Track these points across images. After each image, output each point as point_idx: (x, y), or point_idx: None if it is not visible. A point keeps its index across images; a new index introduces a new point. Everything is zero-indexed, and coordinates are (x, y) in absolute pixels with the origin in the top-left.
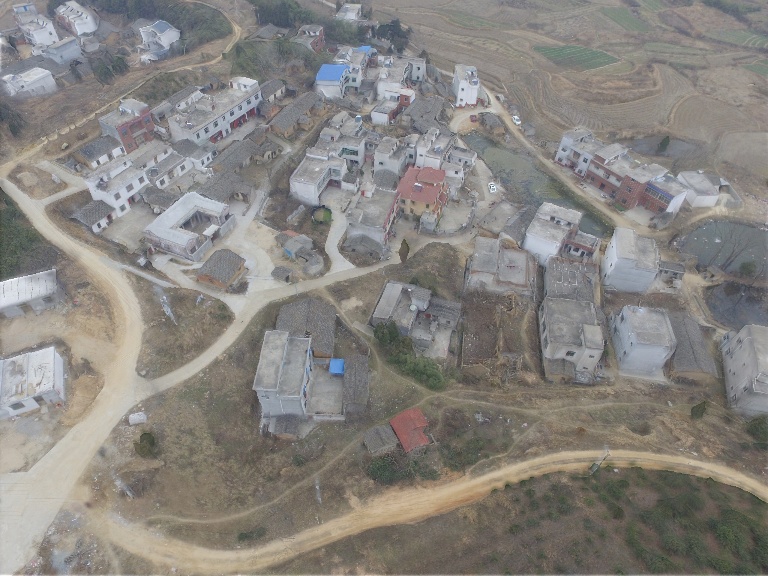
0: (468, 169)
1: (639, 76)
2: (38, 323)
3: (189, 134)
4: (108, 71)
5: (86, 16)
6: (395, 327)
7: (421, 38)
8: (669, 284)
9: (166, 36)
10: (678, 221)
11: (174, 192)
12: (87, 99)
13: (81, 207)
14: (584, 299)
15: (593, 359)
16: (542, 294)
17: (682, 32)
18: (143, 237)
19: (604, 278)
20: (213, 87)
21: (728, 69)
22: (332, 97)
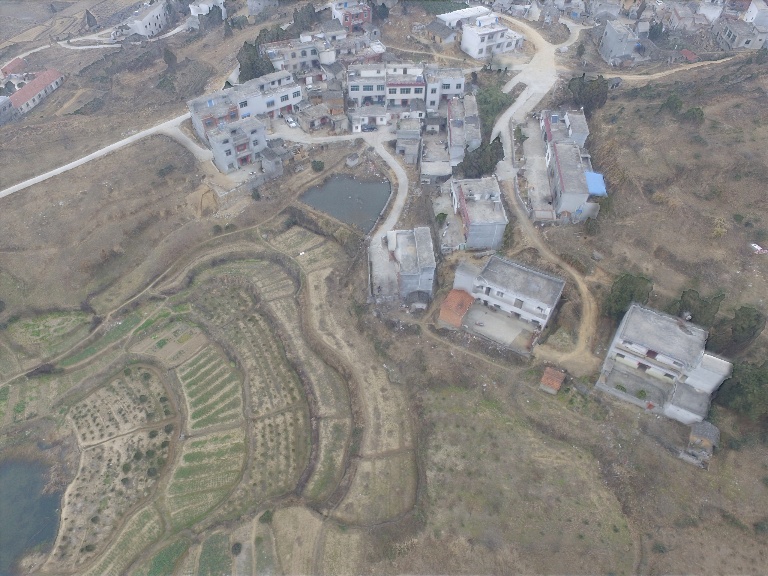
0: None
1: None
2: None
3: None
4: None
5: None
6: None
7: None
8: None
9: None
10: None
11: None
12: None
13: None
14: None
15: (761, 42)
16: None
17: None
18: None
19: None
20: None
21: None
22: None
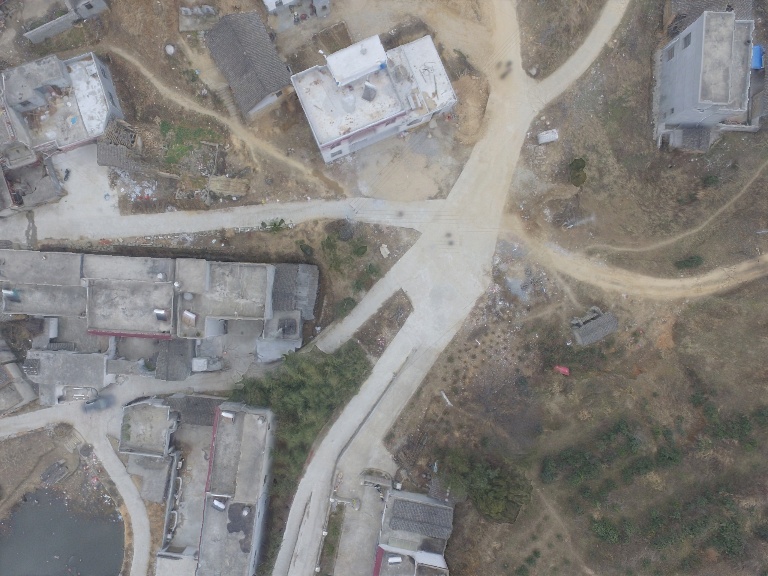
0: None
1: None
2: None
3: None
4: None
5: None
6: None
7: None
8: None
9: None
10: None
11: None
12: None
13: None
14: None
15: None
16: None
17: None
18: None
19: None
20: None
21: None
22: None
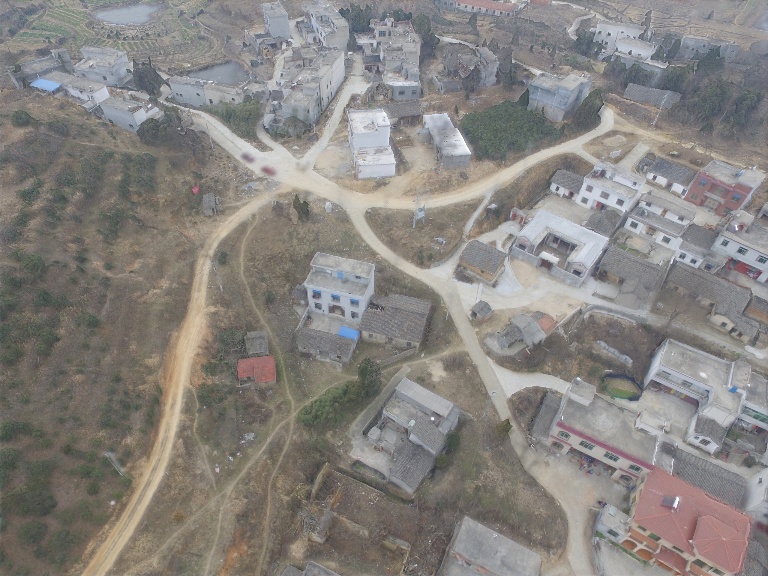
0: None
1: None
2: (426, 159)
3: None
4: None
5: None
6: None
7: None
8: None
9: None
10: None
11: None
12: None
13: None
14: None
15: None
16: None
17: None
18: None
19: None
20: None
21: None
22: None
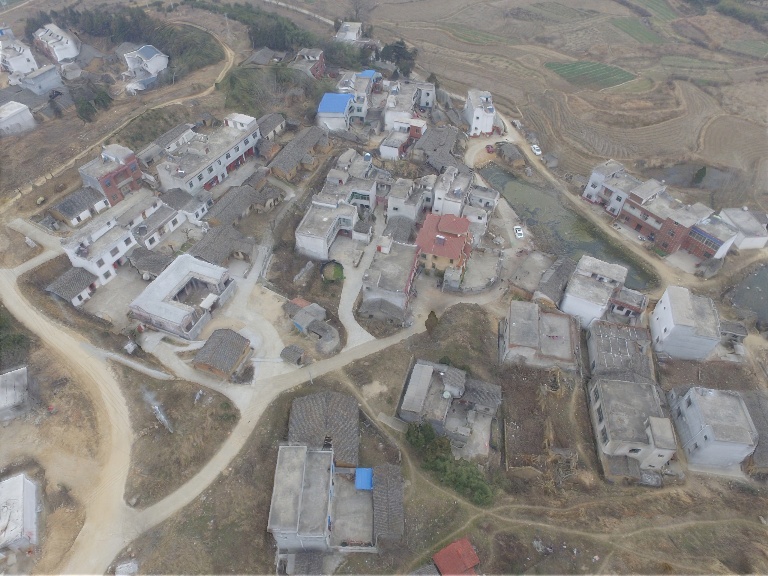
0: (491, 211)
1: (660, 94)
2: (5, 438)
3: (181, 183)
4: (90, 107)
5: (66, 41)
6: (431, 429)
7: (425, 56)
8: (729, 348)
9: (153, 62)
10: (726, 267)
11: (165, 251)
12: (67, 140)
13: (59, 274)
14: (641, 376)
15: (662, 458)
16: (588, 365)
17: (698, 44)
18: (131, 310)
19: (656, 343)
20: (206, 124)
21: (753, 85)
22: (336, 130)
